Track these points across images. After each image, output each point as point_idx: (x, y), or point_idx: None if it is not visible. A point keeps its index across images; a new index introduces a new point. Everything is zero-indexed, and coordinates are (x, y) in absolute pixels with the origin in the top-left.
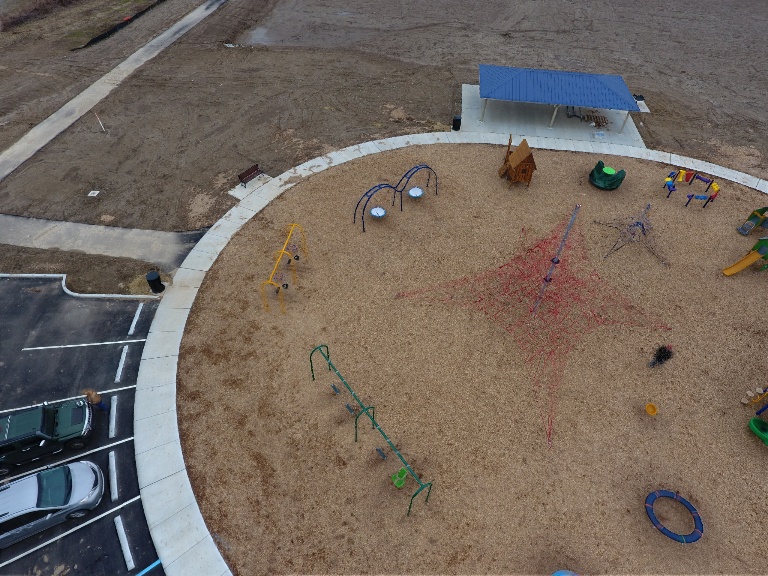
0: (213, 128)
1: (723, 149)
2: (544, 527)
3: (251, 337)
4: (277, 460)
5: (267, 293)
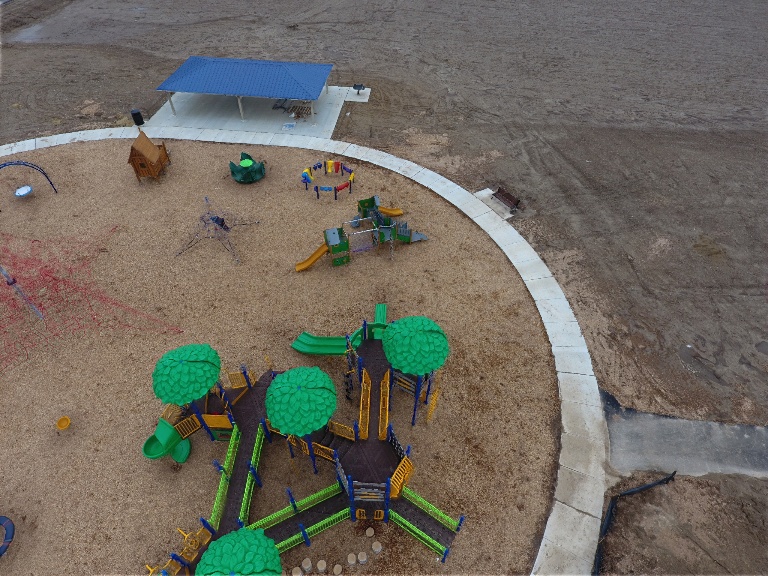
0: None
1: (412, 138)
2: None
3: None
4: None
5: None
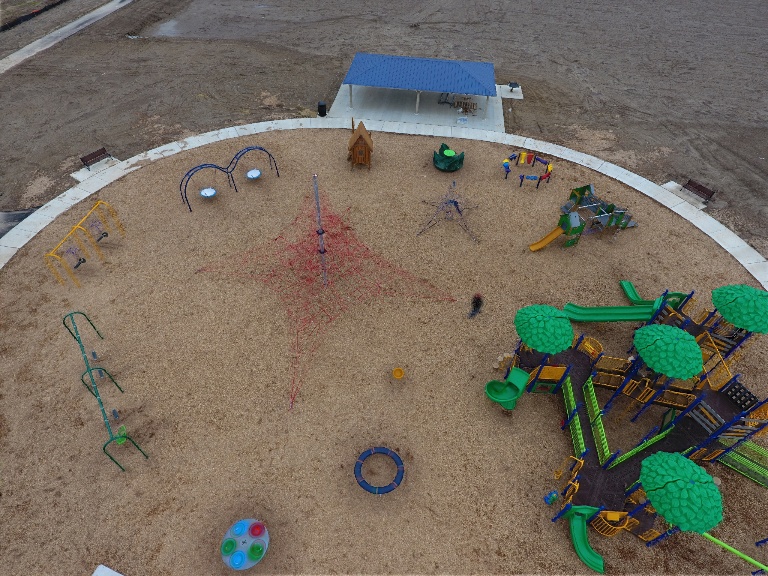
0: (79, 114)
1: (581, 133)
2: (253, 481)
3: (38, 309)
4: (16, 421)
5: (70, 268)
